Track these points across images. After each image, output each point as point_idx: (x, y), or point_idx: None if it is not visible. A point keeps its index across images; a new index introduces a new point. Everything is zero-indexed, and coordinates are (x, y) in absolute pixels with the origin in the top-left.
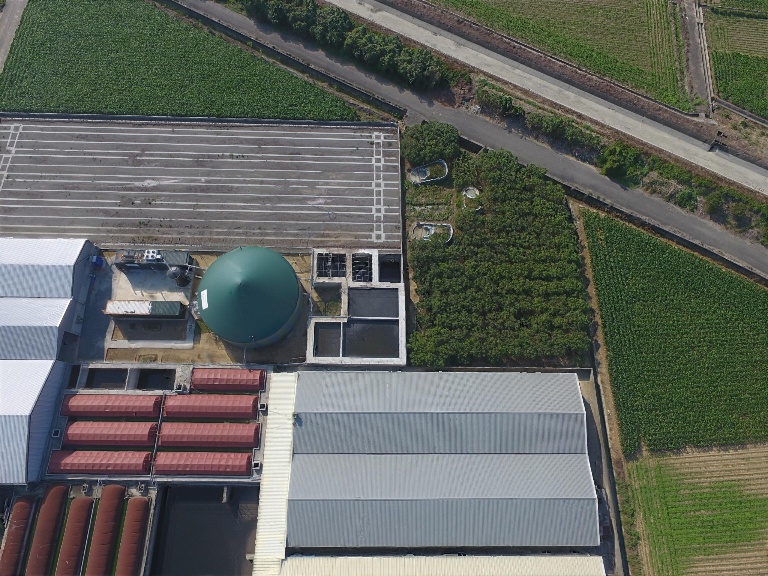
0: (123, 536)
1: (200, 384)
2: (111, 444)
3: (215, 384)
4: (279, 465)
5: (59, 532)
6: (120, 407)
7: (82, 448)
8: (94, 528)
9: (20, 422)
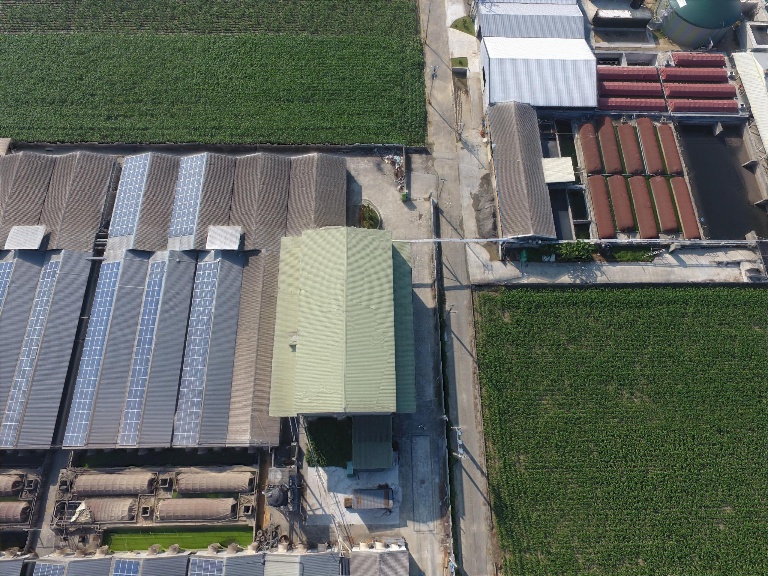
0: (666, 144)
1: (683, 60)
2: (633, 94)
3: (694, 60)
4: (762, 102)
5: (617, 144)
6: (634, 71)
7: (613, 97)
8: (641, 141)
9: (590, 64)
